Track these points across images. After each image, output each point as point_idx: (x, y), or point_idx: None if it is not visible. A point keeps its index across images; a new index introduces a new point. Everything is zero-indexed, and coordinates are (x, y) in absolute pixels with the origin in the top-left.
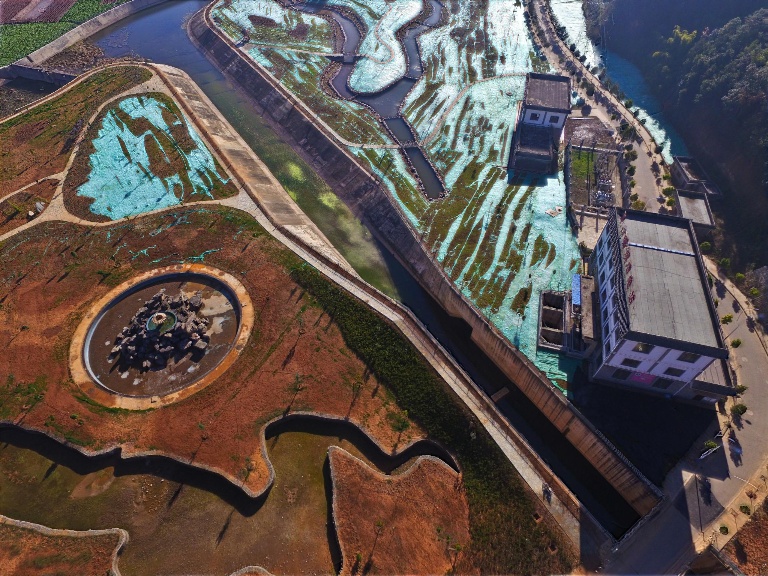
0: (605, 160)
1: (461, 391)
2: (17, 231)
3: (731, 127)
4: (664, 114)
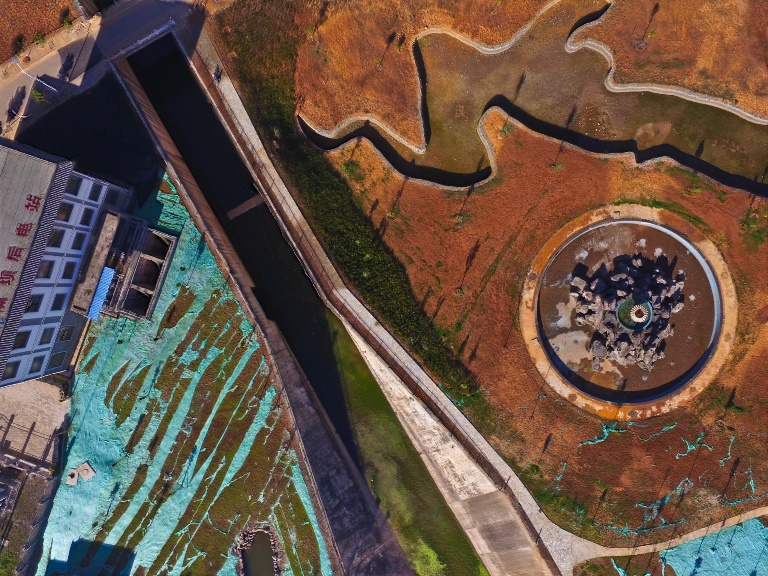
0: None
1: (279, 187)
2: None
3: None
4: None
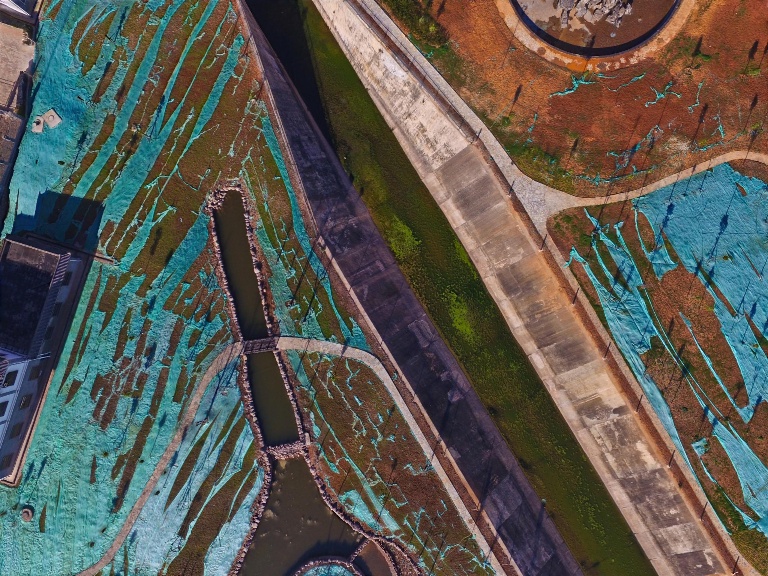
0: None
1: None
2: None
3: None
4: None
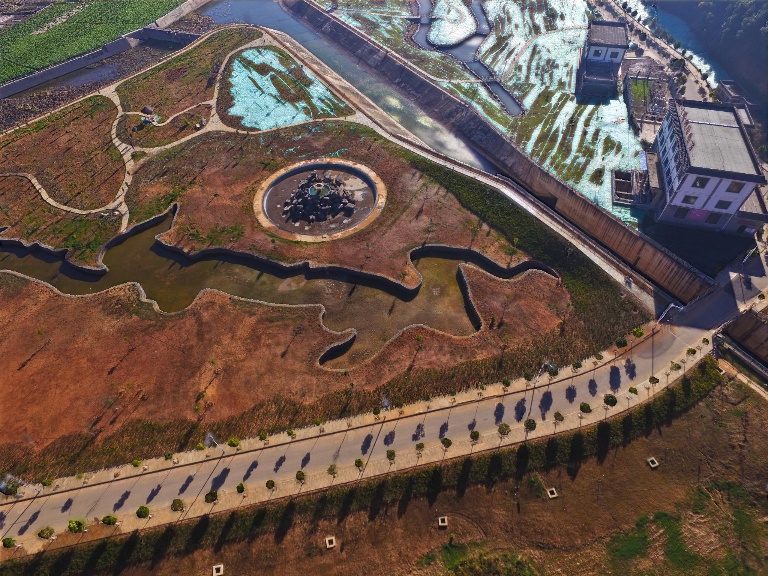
0: (659, 84)
1: (557, 228)
2: (191, 137)
3: (767, 53)
4: (708, 53)
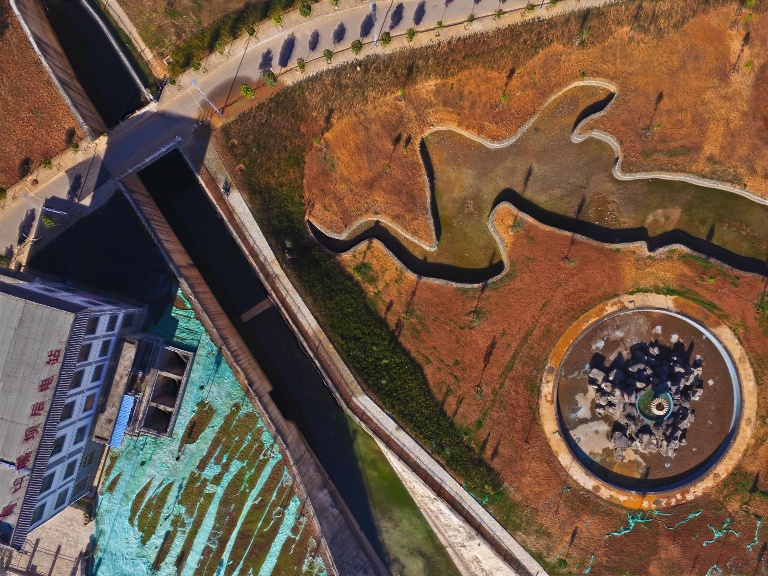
0: None
1: (294, 297)
2: None
3: None
4: None
